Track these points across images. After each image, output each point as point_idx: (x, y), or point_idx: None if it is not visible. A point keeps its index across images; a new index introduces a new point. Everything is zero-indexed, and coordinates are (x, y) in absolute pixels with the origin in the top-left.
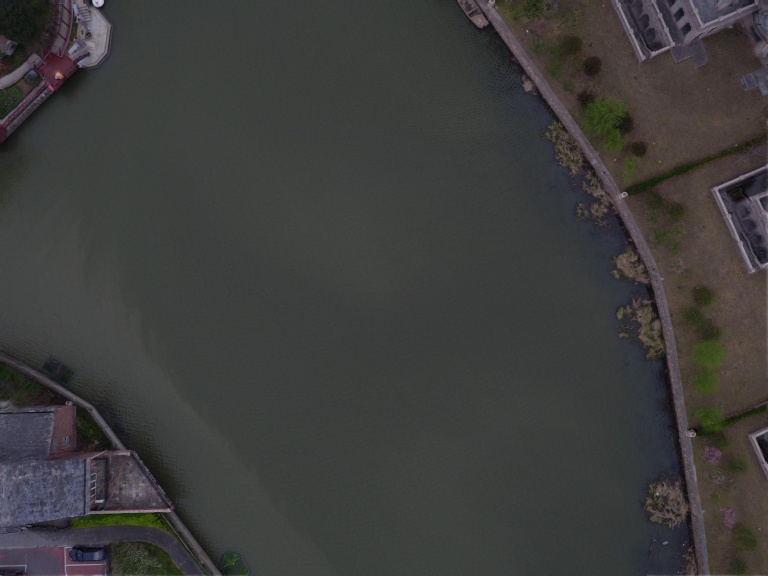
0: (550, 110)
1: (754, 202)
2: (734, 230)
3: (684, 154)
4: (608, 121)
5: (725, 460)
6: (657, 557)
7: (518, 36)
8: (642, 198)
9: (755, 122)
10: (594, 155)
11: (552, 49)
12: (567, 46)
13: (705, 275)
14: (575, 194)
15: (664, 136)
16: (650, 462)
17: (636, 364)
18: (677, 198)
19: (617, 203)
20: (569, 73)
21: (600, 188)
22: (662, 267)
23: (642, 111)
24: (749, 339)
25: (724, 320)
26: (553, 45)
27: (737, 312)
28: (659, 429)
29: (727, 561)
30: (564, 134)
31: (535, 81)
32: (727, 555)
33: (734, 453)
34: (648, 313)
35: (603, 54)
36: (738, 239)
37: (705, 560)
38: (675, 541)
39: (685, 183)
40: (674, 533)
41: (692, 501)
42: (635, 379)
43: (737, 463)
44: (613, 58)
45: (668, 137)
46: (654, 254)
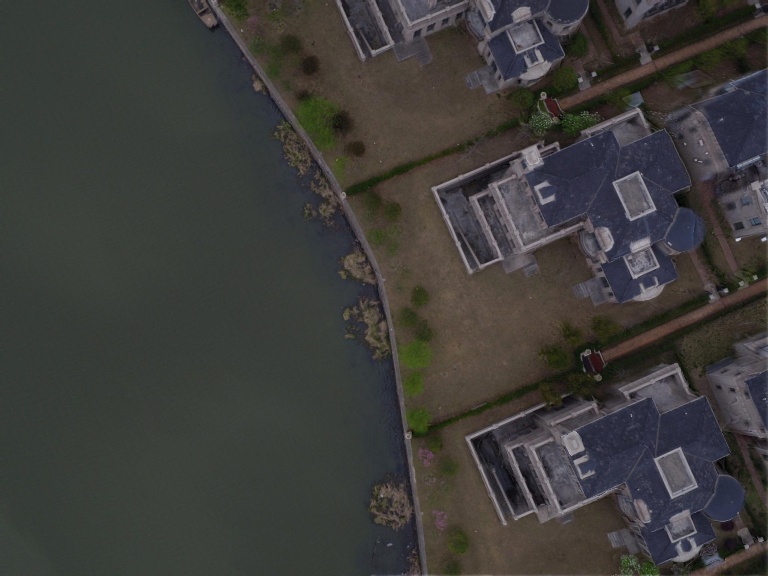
0: (278, 110)
1: (471, 202)
2: (452, 230)
3: (406, 154)
4: (329, 121)
5: (441, 462)
6: (381, 559)
7: (242, 35)
8: (362, 198)
9: (479, 121)
10: (318, 155)
11: (274, 48)
12: (289, 45)
13: (425, 276)
14: (303, 194)
15: (386, 135)
16: (375, 464)
17: (362, 365)
18: (398, 198)
19: (342, 203)
20: (291, 72)
21: (328, 188)
22: (384, 268)
23: (364, 110)
24: (468, 340)
25: (444, 321)
26: (275, 44)
27: (457, 313)
28: (385, 431)
29: (445, 563)
30: (293, 134)
31: (263, 80)
32: (444, 557)
33: (452, 455)
34: (374, 314)
35: (325, 53)
36: (456, 239)
37: (423, 562)
38: (399, 543)
39: (407, 183)
40: (399, 535)
41: (414, 503)
42: (361, 380)
43: (454, 465)
44: (335, 57)
45: (390, 136)
46: (376, 255)
